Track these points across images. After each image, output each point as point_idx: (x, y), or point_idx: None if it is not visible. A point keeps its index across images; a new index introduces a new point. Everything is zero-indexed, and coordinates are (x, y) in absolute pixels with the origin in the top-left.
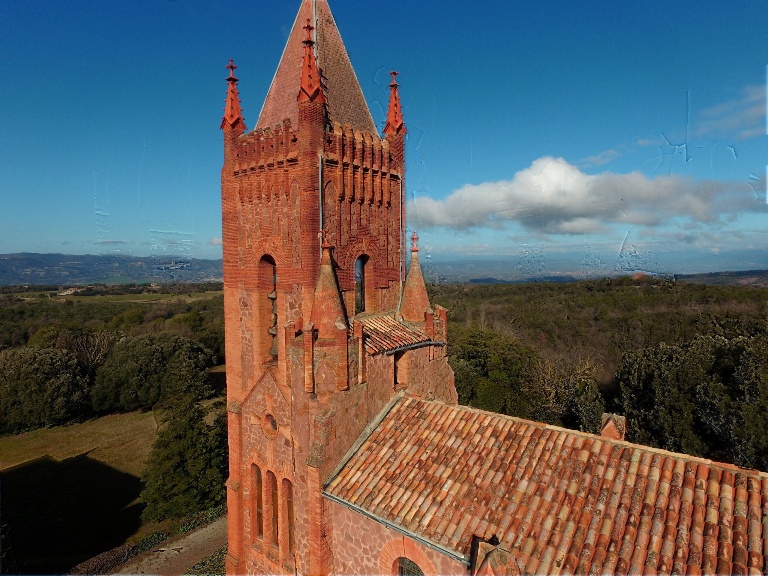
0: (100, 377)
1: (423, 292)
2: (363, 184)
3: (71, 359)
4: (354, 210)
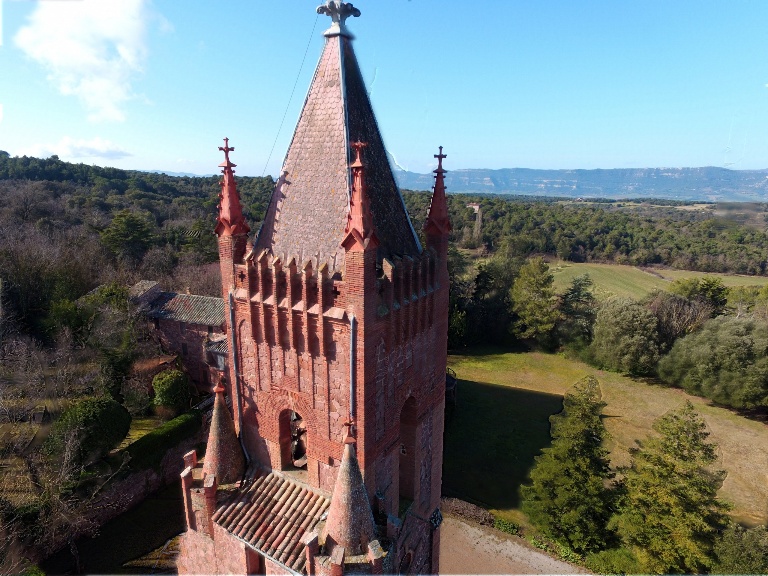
0: (675, 349)
1: (337, 506)
2: (284, 326)
3: (651, 322)
4: (277, 355)
